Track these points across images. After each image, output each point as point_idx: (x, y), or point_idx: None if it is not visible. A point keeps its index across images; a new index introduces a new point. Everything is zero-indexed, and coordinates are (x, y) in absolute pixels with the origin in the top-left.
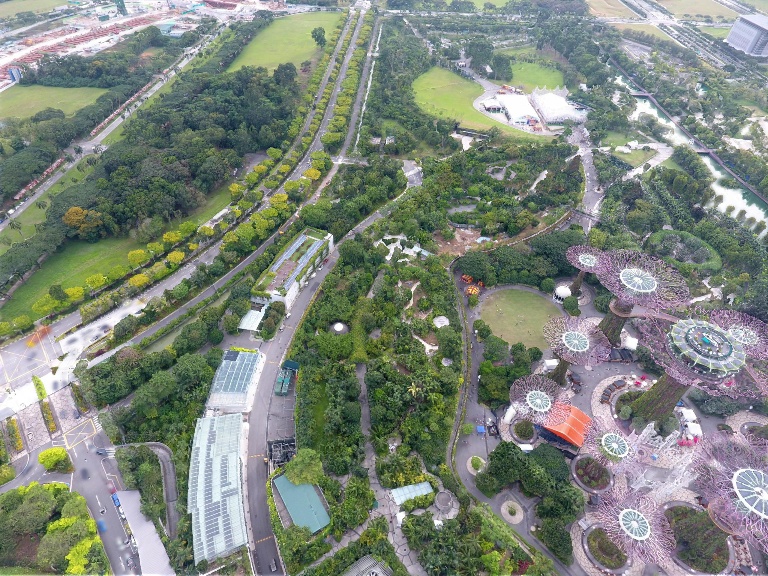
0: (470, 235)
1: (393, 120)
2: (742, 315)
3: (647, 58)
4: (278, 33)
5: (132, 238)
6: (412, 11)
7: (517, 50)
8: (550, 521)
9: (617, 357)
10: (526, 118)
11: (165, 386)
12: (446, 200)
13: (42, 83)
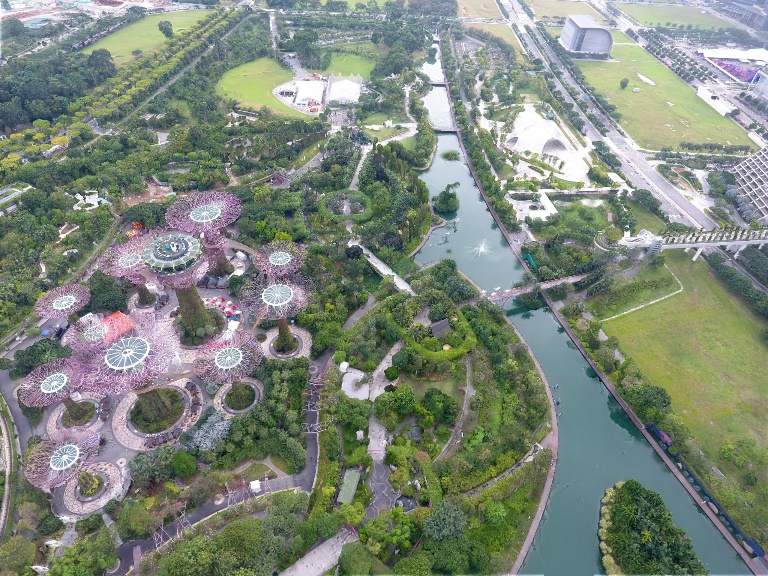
0: (165, 191)
1: (185, 101)
2: (294, 244)
3: (474, 53)
4: (143, 27)
5: None
6: (286, 10)
7: (358, 45)
8: None
9: (211, 283)
10: (307, 100)
11: None
12: (162, 163)
13: None
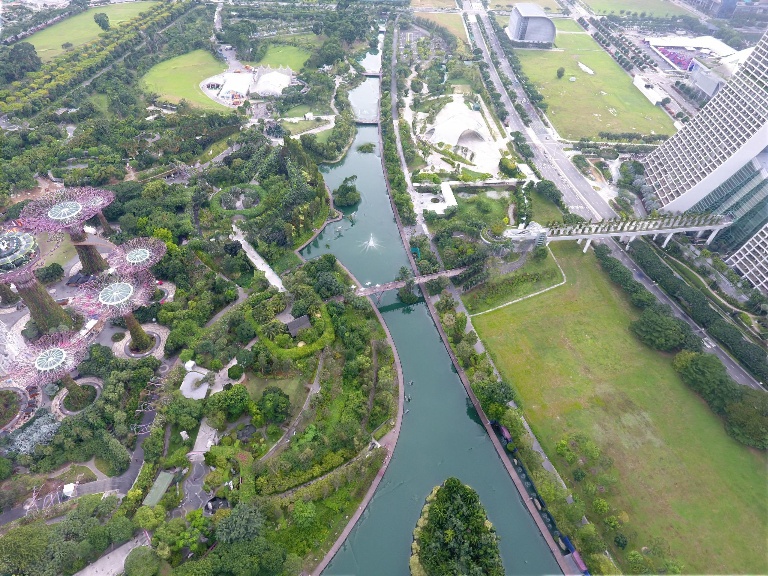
0: (58, 187)
1: (106, 94)
2: (156, 241)
3: None
4: (83, 20)
5: None
6: (235, 1)
7: (300, 36)
8: None
9: (80, 282)
10: (231, 93)
11: None
12: (60, 158)
13: None
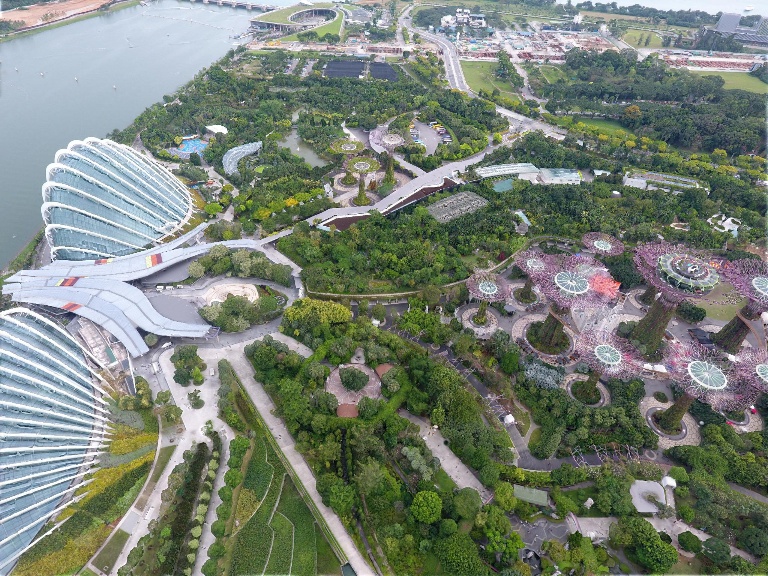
0: None
1: None
2: None
3: None
4: None
5: (634, 132)
6: None
7: None
8: None
9: (699, 338)
10: None
11: (541, 146)
12: None
13: (761, 78)
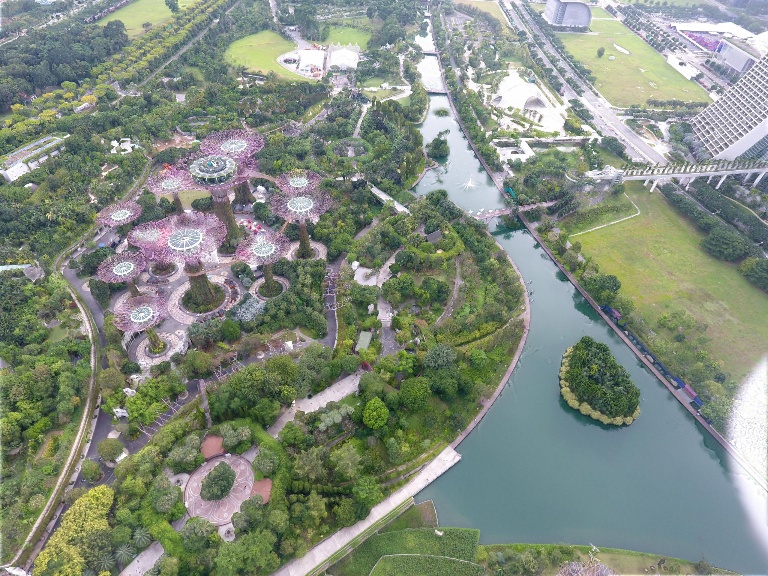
0: (189, 140)
1: (196, 67)
2: (309, 172)
3: (463, 26)
4: (148, 4)
5: None
6: None
7: None
8: (92, 279)
9: (237, 209)
10: (310, 67)
11: None
12: (184, 116)
13: None
